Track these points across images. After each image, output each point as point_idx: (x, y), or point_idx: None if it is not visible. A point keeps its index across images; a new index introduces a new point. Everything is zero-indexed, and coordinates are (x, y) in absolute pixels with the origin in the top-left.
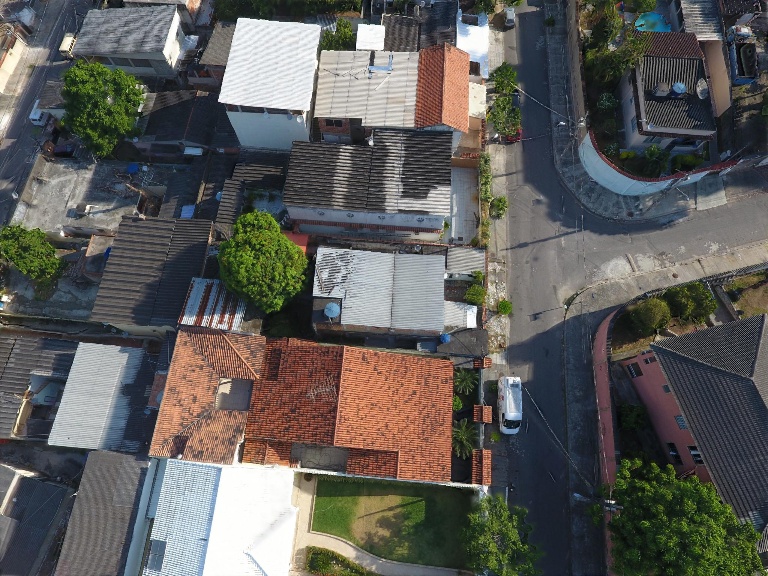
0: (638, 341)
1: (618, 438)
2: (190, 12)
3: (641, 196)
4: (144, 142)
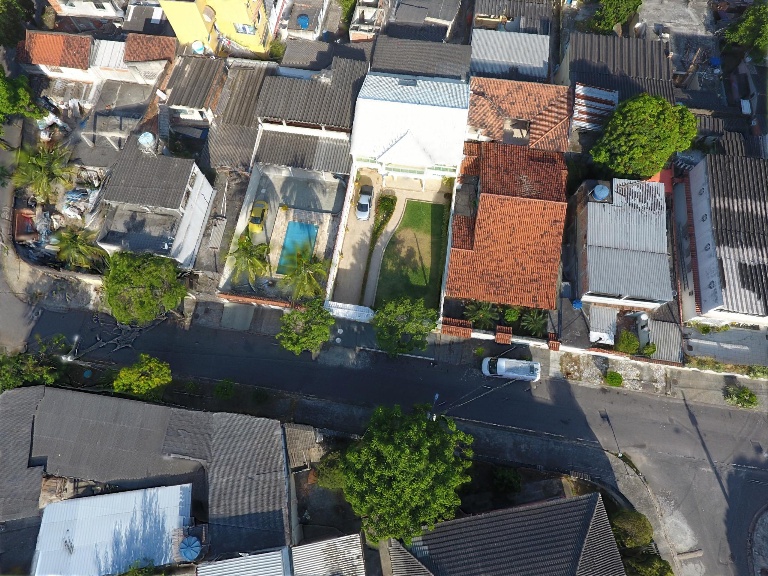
0: None
1: (483, 468)
2: None
3: None
4: (747, 67)
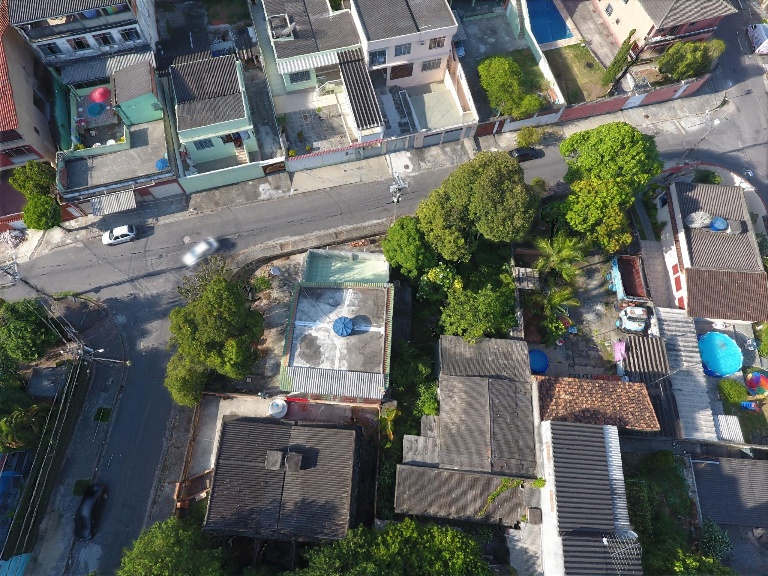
0: None
1: None
2: None
3: None
4: None
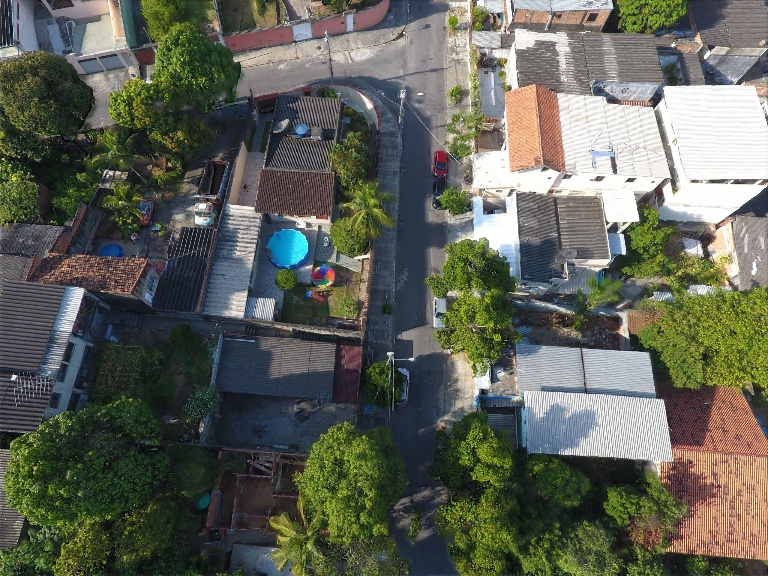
0: (362, 1)
1: None
2: None
3: None
4: None
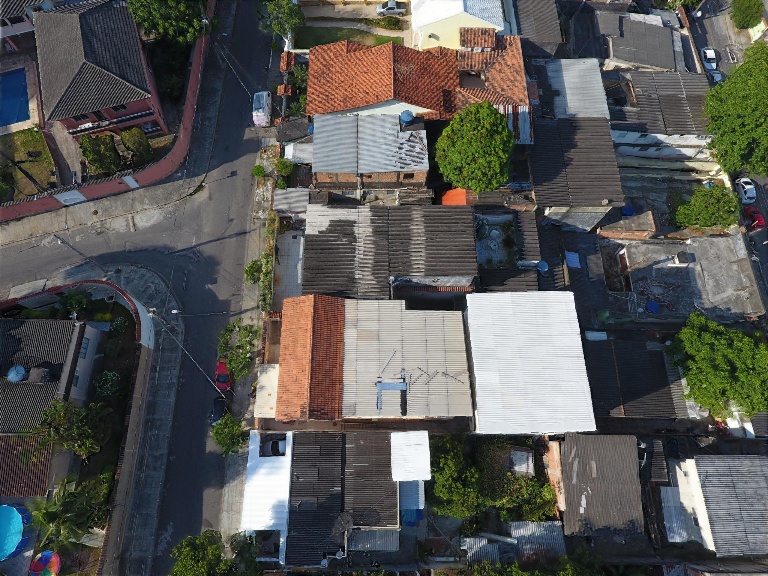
0: None
1: None
2: (699, 574)
3: None
4: (658, 343)
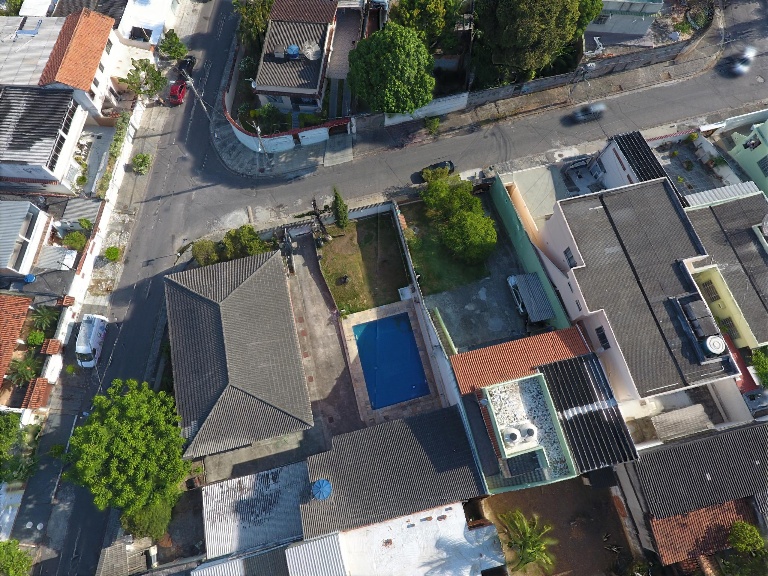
0: None
1: None
2: None
3: (275, 153)
4: None
